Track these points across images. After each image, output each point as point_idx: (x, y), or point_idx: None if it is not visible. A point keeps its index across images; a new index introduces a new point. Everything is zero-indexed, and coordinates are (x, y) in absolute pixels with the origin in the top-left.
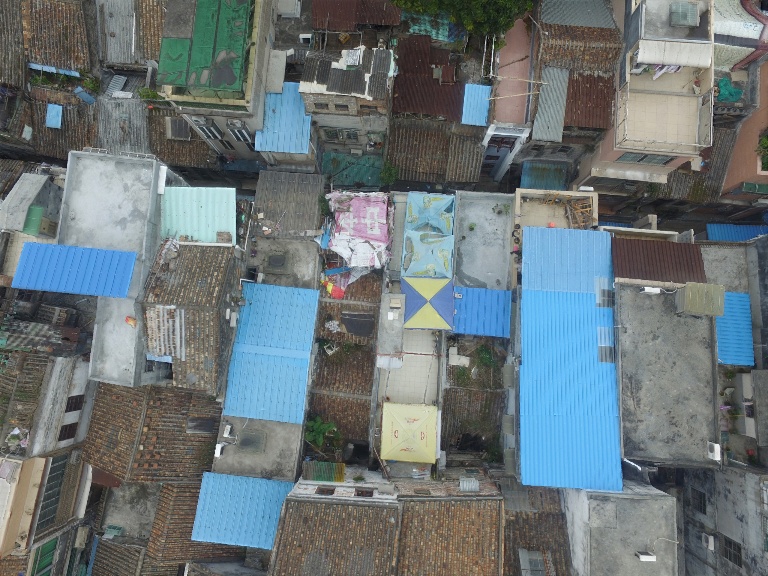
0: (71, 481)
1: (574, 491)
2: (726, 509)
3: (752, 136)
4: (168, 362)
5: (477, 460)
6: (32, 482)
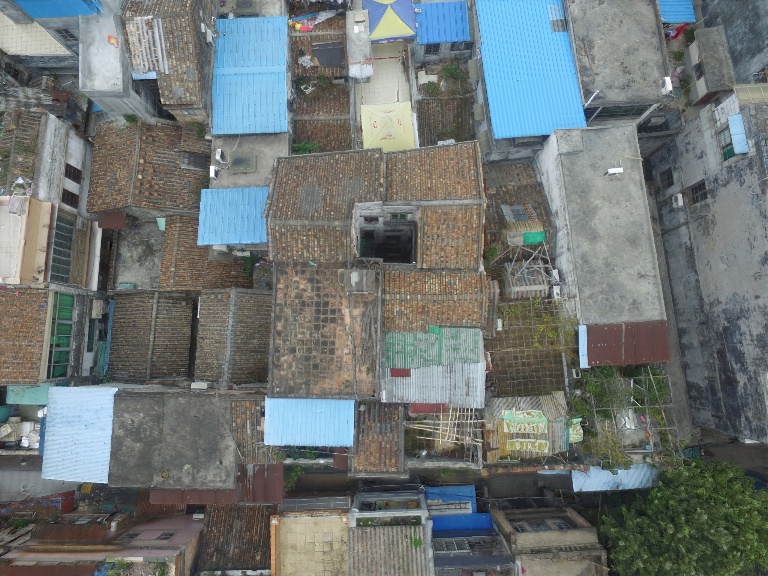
0: (79, 244)
1: (545, 149)
2: (689, 161)
3: None
4: (153, 78)
5: None
6: (42, 223)
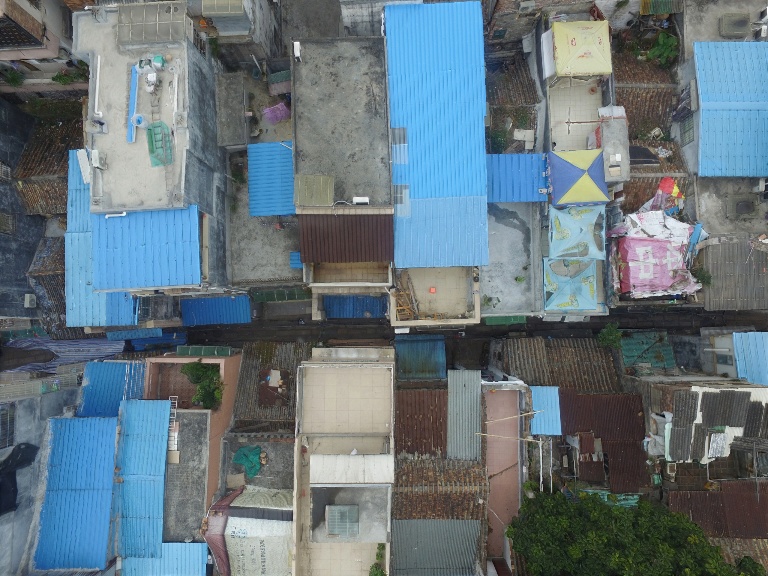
0: None
1: None
2: None
3: (226, 406)
4: None
5: (487, 53)
6: None
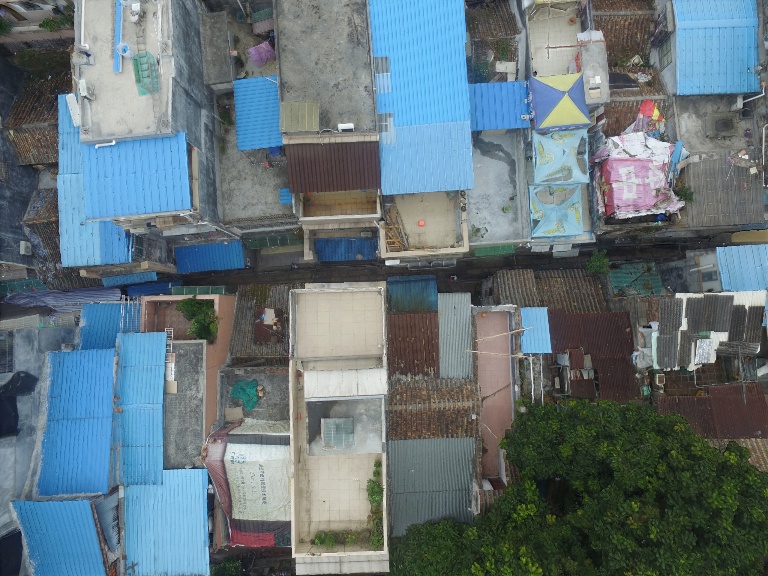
0: None
1: None
2: None
3: (221, 341)
4: None
5: None
6: None
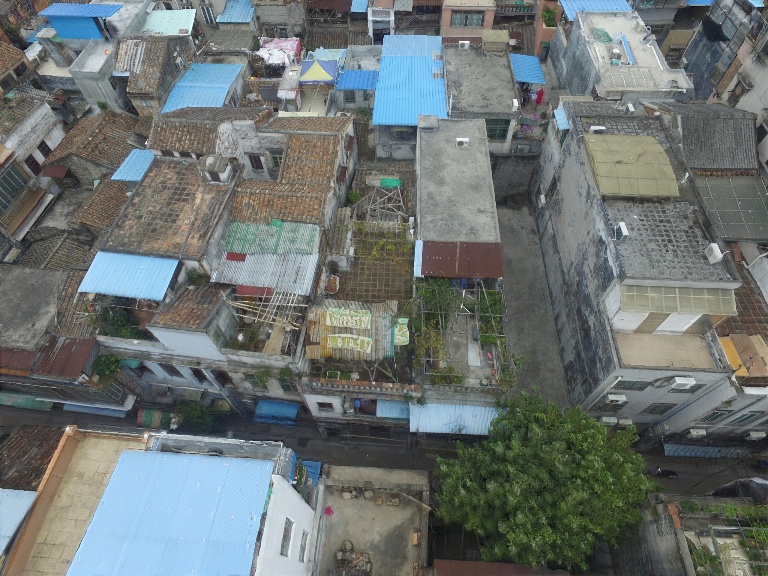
0: (23, 196)
1: None
2: (546, 169)
3: None
4: (127, 76)
5: None
6: None
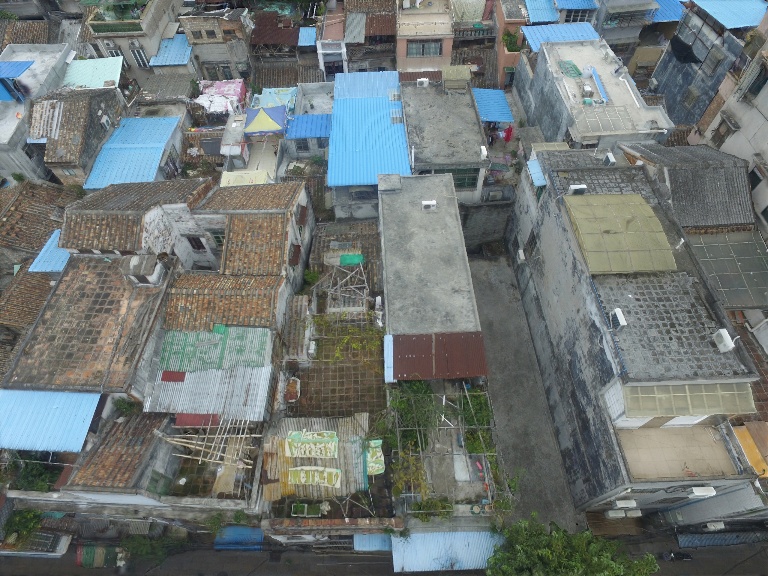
0: None
1: None
2: (523, 220)
3: None
4: (43, 143)
5: None
6: None
